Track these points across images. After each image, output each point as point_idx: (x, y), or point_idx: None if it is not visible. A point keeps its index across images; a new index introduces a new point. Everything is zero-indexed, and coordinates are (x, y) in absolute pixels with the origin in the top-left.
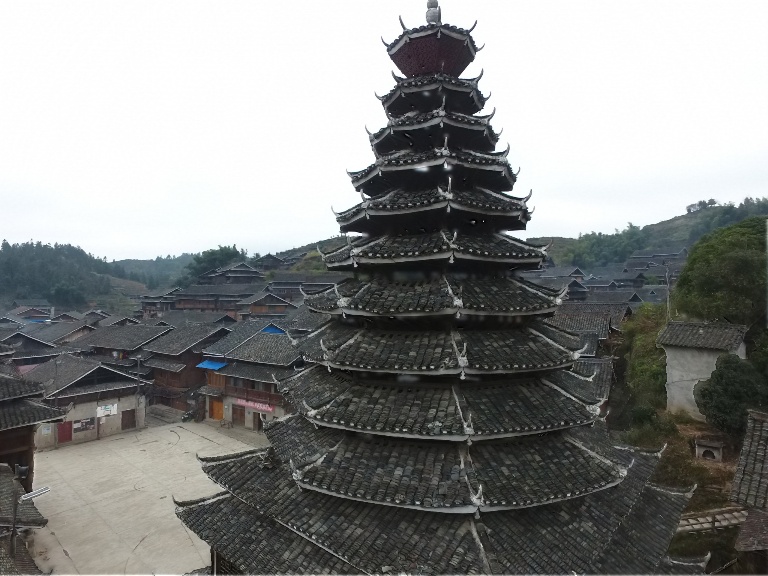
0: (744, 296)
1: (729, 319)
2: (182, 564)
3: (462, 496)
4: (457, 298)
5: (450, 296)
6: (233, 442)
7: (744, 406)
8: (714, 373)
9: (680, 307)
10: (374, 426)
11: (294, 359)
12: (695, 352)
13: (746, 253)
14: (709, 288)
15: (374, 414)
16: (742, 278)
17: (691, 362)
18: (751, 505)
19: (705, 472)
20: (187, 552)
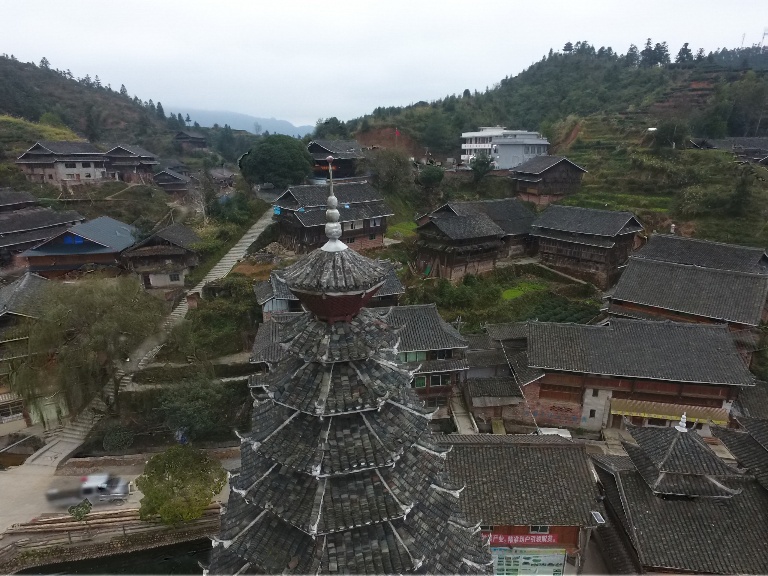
0: None
1: None
2: None
3: None
4: None
5: None
6: None
7: None
8: None
9: None
10: None
11: None
12: None
13: None
14: None
15: None
16: None
17: None
18: None
19: None
20: None
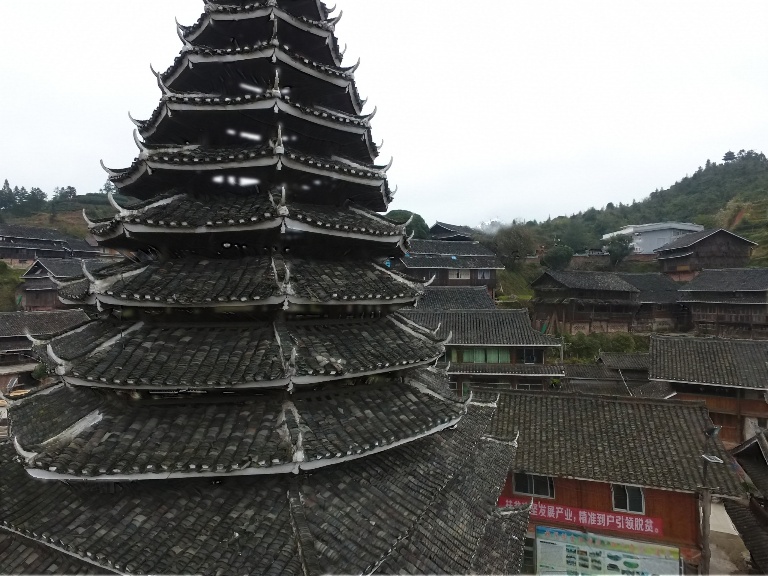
0: None
1: None
2: None
3: None
4: None
5: None
6: None
7: None
8: None
9: None
10: None
11: None
12: None
13: None
14: None
15: None
16: None
17: None
18: None
19: None
20: None
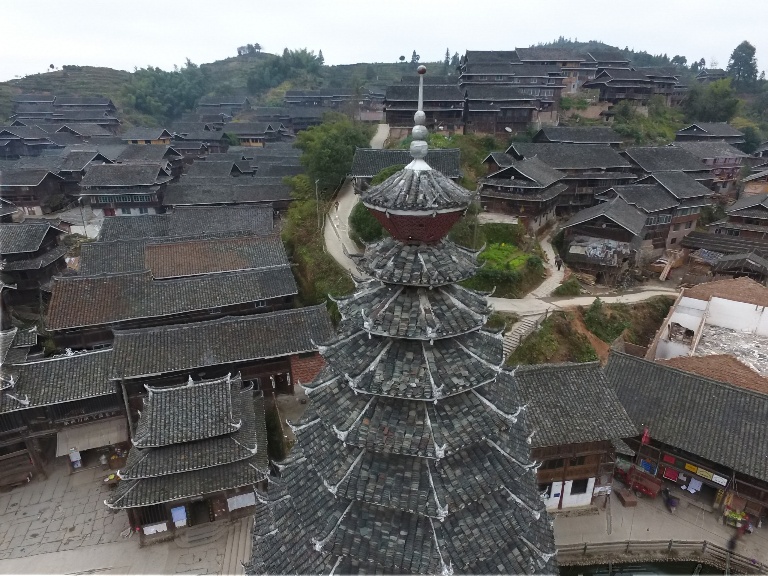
0: None
1: None
2: None
3: None
4: (539, 513)
5: (525, 508)
6: None
7: None
8: None
9: None
10: None
11: None
12: None
13: None
14: None
15: None
16: None
17: None
18: None
19: None
20: None
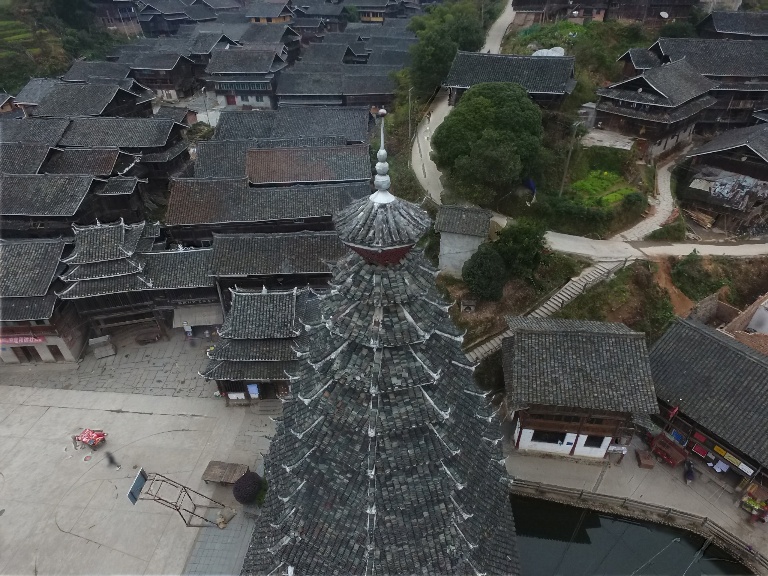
0: (493, 189)
1: (481, 206)
2: (110, 570)
3: (471, 574)
4: (461, 486)
5: (451, 479)
6: (9, 392)
7: (493, 284)
8: (477, 262)
9: (447, 188)
10: (415, 567)
11: (48, 283)
12: (461, 235)
13: (498, 154)
14: (470, 179)
15: (408, 556)
16: (493, 174)
17: (457, 241)
18: (524, 401)
19: (468, 325)
20: (102, 556)
